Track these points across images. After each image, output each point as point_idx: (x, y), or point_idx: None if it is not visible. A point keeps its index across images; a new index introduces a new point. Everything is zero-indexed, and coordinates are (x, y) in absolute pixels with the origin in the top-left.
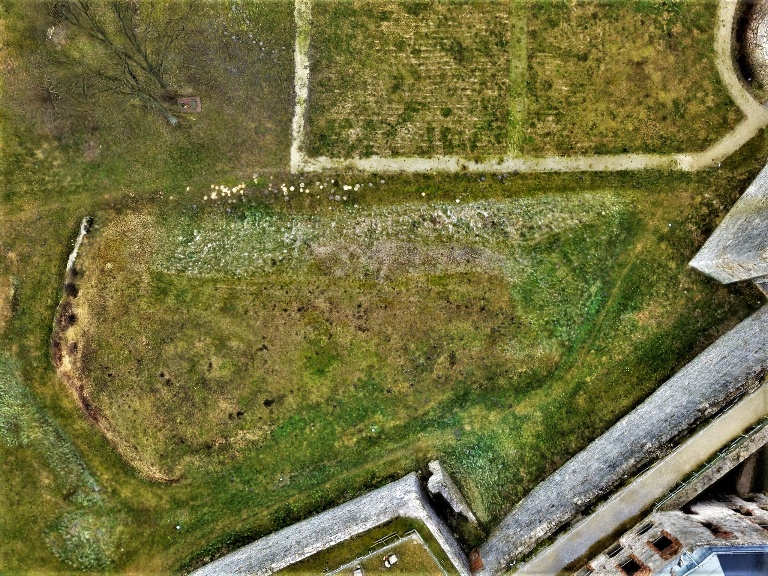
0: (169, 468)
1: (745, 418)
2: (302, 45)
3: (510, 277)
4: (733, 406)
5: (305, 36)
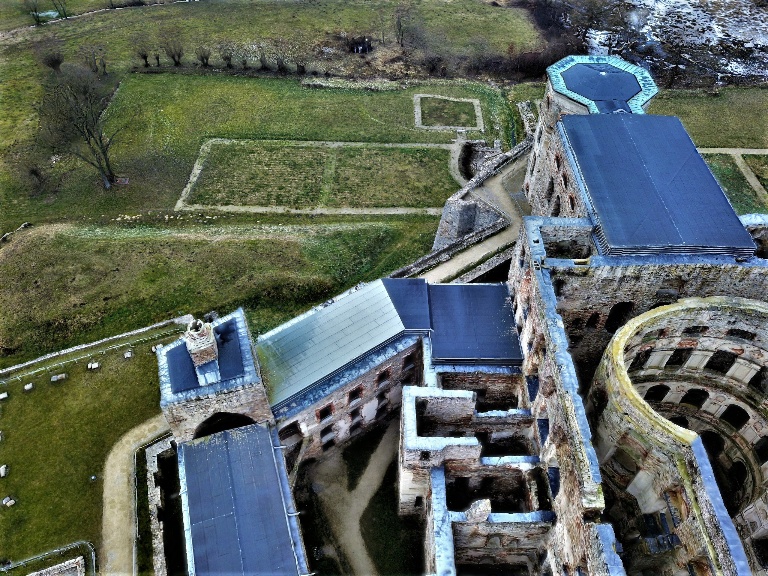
0: (11, 338)
1: (441, 275)
2: (200, 161)
3: (302, 244)
4: (432, 269)
5: (203, 158)
